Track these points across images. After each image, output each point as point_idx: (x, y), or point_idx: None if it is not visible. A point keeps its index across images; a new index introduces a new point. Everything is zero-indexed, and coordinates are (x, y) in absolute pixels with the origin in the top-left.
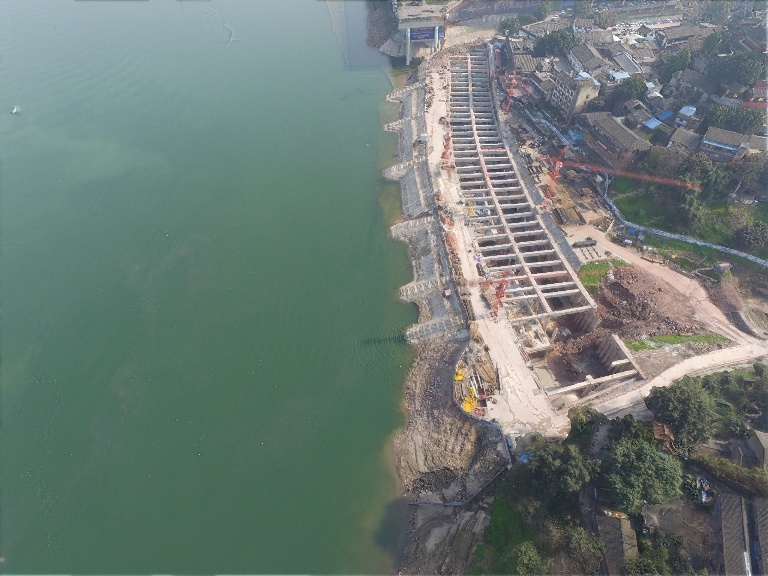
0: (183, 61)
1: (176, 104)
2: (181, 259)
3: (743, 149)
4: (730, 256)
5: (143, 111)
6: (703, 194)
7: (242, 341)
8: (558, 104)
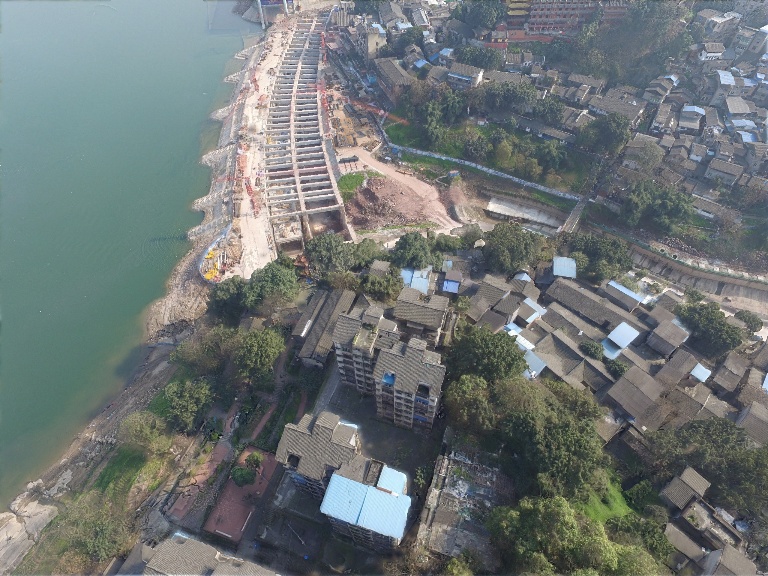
0: (58, 27)
1: (38, 62)
2: (7, 183)
3: (474, 79)
4: (465, 167)
5: (6, 68)
6: (446, 117)
7: (45, 242)
8: (361, 53)
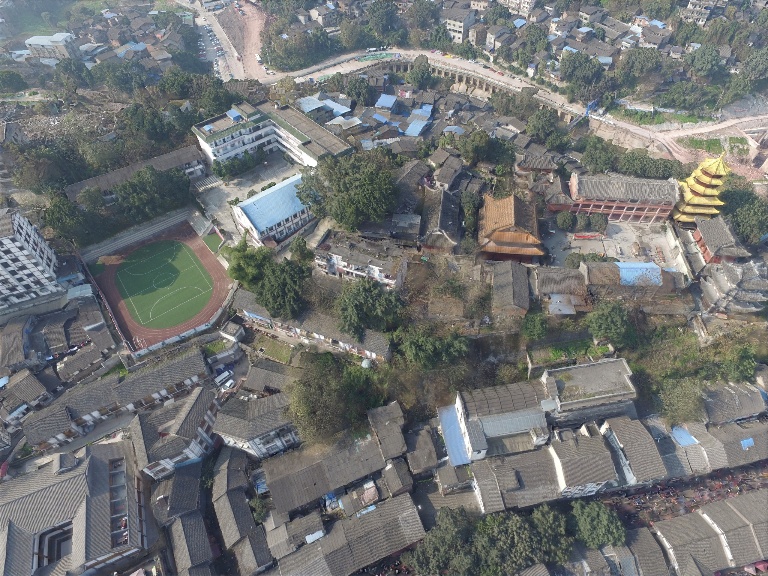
0: None
1: None
2: None
3: None
4: None
5: None
6: None
7: None
8: None
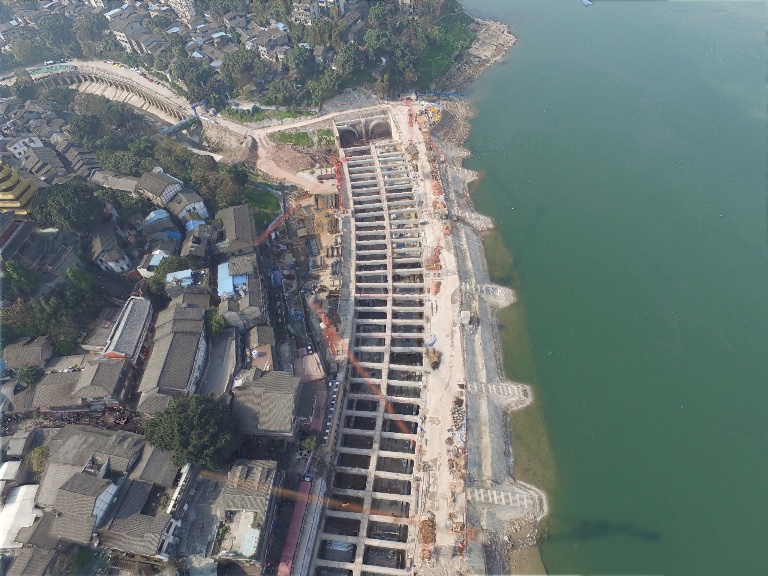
0: None
1: None
2: (684, 194)
3: None
4: None
5: None
6: None
7: None
8: None
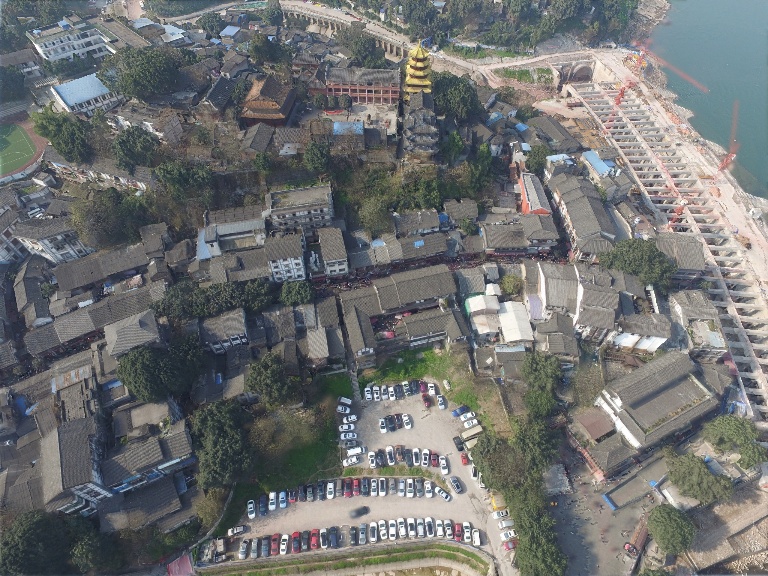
0: None
1: None
2: None
3: None
4: None
5: None
6: None
7: None
8: None
